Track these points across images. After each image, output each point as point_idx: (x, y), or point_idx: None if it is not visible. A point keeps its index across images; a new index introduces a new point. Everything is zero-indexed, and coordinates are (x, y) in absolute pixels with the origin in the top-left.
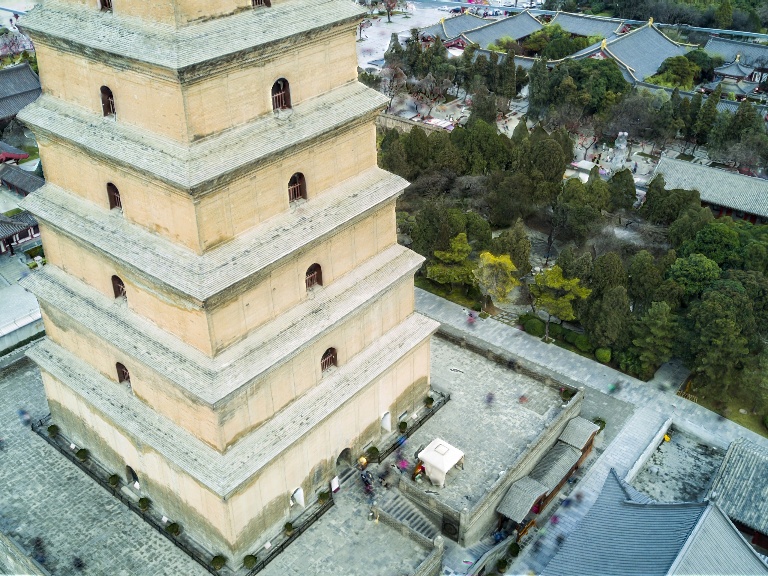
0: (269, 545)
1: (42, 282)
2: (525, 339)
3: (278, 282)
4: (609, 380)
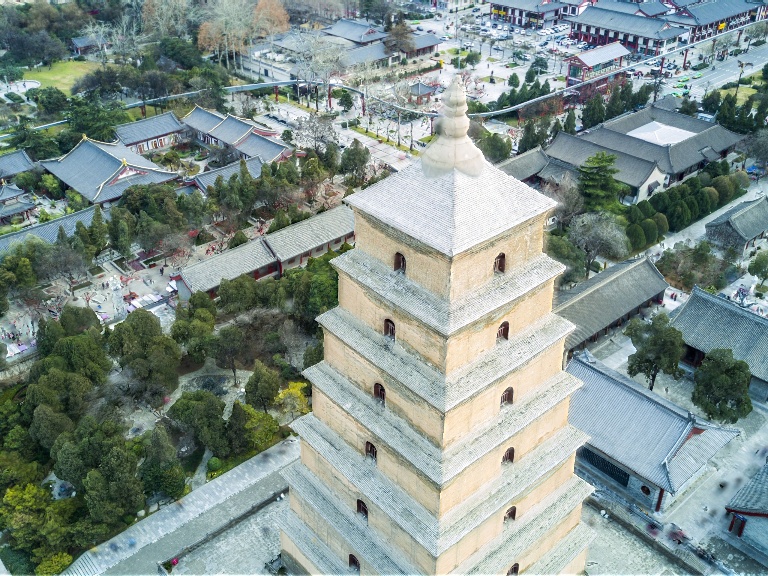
0: None
1: None
2: None
3: None
4: None
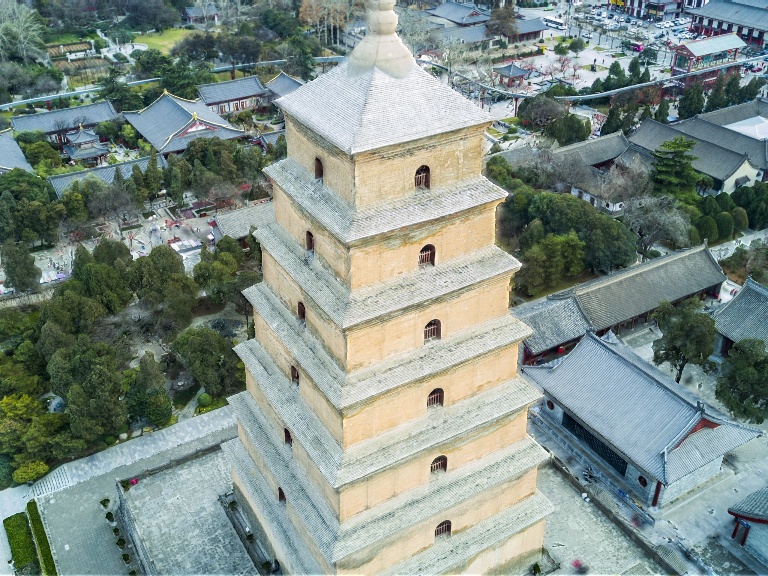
0: None
1: (355, 537)
2: None
3: None
4: None
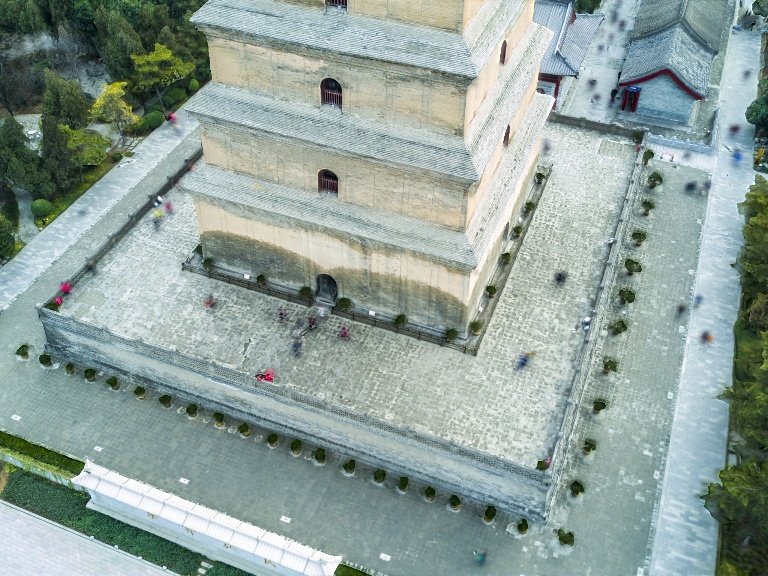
0: None
1: None
2: (168, 128)
3: None
4: None
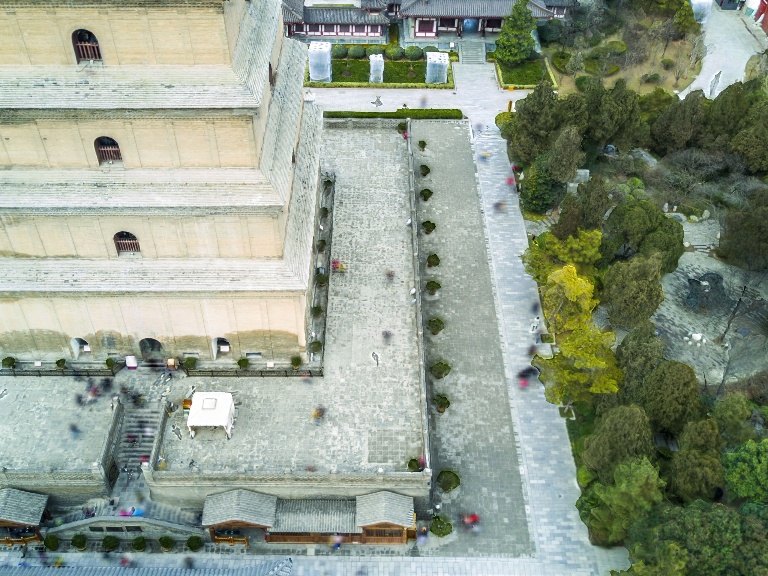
0: (39, 364)
1: None
2: None
3: (51, 134)
4: (555, 504)
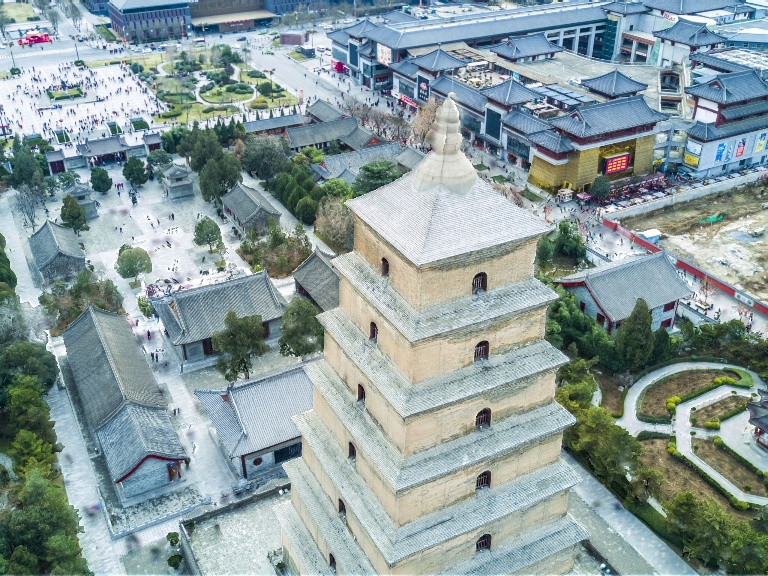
0: None
1: None
2: None
3: None
4: None
